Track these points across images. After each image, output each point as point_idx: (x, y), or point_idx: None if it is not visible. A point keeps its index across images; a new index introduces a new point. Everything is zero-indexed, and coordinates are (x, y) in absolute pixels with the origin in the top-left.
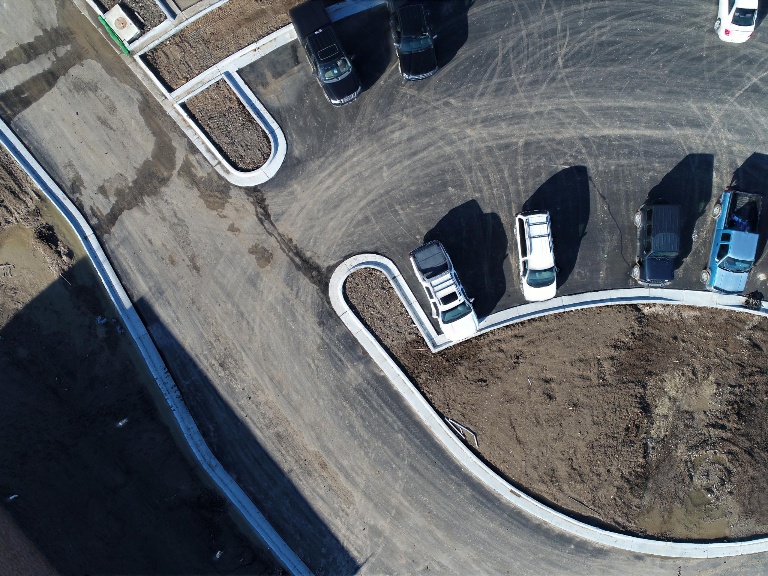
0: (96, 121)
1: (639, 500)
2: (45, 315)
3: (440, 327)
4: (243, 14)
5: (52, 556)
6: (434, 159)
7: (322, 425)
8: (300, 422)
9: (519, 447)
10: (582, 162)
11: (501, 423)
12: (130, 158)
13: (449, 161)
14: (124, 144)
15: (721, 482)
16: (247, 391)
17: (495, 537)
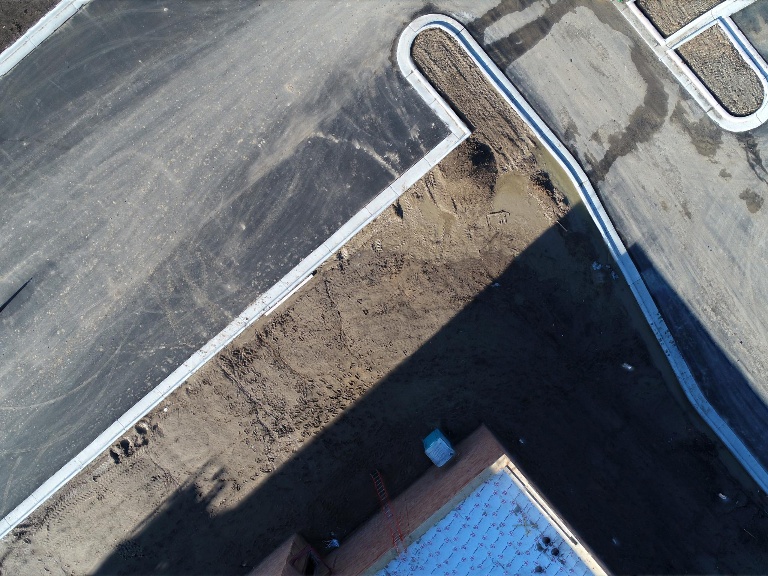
0: (589, 68)
1: None
2: (541, 262)
3: None
4: None
5: (553, 500)
6: None
7: None
8: None
9: None
10: None
11: None
12: (623, 104)
13: None
14: (617, 91)
15: None
16: (739, 335)
17: None
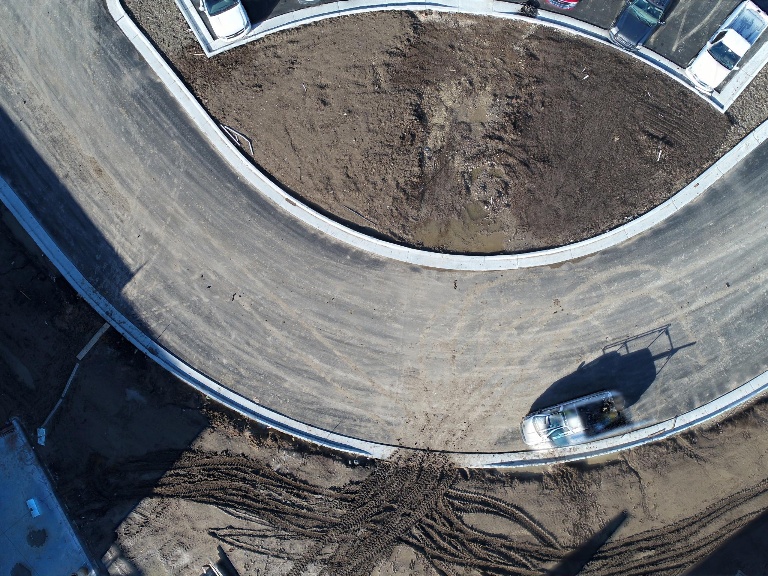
0: None
1: (415, 211)
2: None
3: None
4: None
5: None
6: None
7: (97, 131)
8: (75, 127)
9: (294, 154)
10: None
11: (276, 129)
12: None
13: None
14: None
15: (498, 194)
16: (22, 95)
17: (270, 247)
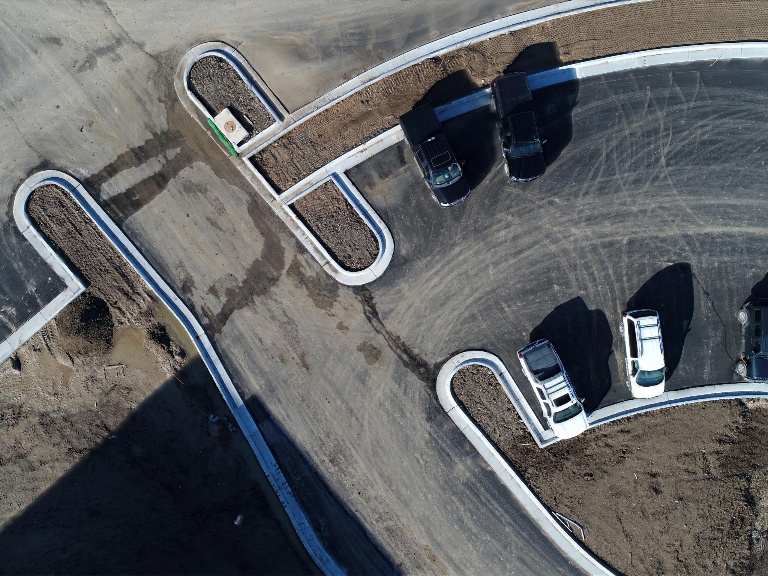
0: (206, 222)
1: None
2: (158, 414)
3: (547, 423)
4: (350, 116)
5: None
6: (539, 257)
7: (430, 519)
8: (409, 516)
9: (625, 540)
10: (686, 259)
11: (608, 516)
12: (240, 259)
13: (554, 259)
14: (234, 245)
15: None
16: (356, 486)
17: None
